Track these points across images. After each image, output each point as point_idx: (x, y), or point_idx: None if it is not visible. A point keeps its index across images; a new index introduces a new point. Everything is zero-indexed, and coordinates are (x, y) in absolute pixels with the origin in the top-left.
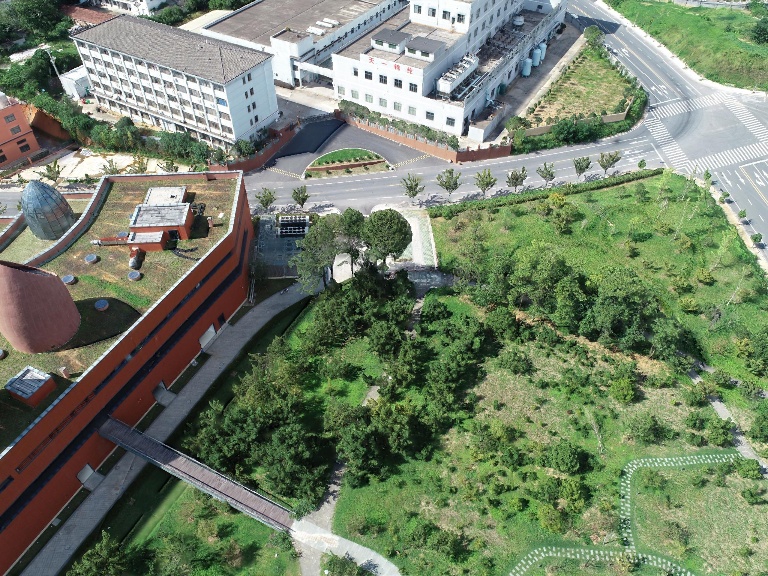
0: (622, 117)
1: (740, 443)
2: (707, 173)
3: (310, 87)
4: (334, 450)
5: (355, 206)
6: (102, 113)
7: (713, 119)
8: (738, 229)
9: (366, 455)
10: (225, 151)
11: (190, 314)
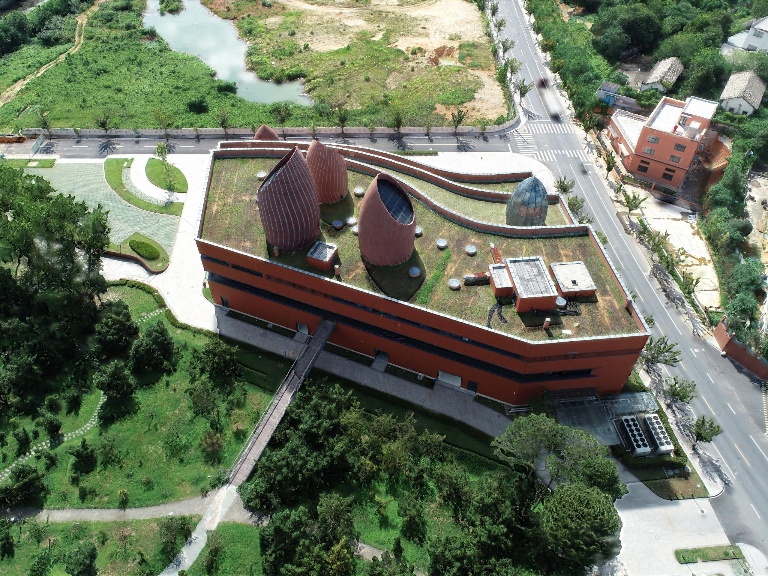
0: None
1: None
2: None
3: None
4: None
5: (742, 517)
6: (762, 208)
7: None
8: None
9: (277, 540)
10: (761, 331)
11: (442, 346)
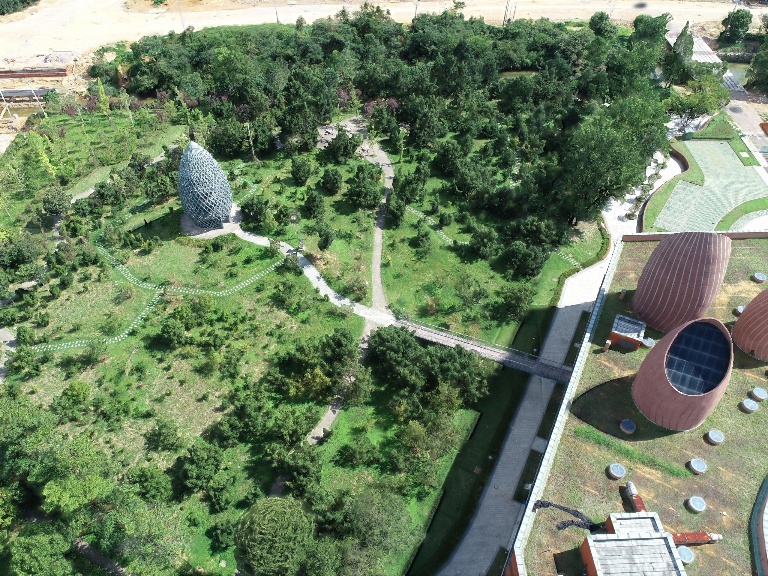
0: None
1: None
2: None
3: None
4: None
5: None
6: None
7: None
8: None
9: None
10: None
11: None
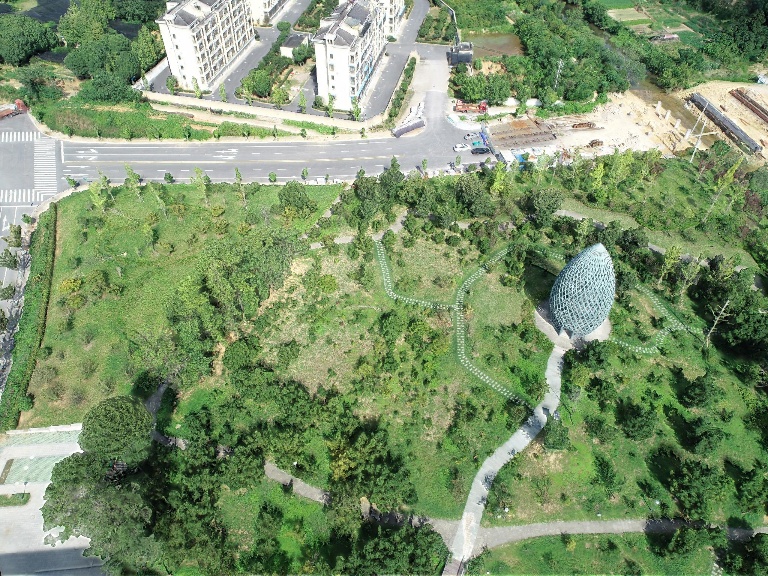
0: None
1: None
2: (70, 180)
3: None
4: (374, 525)
5: None
6: None
7: None
8: None
9: None
10: None
11: None
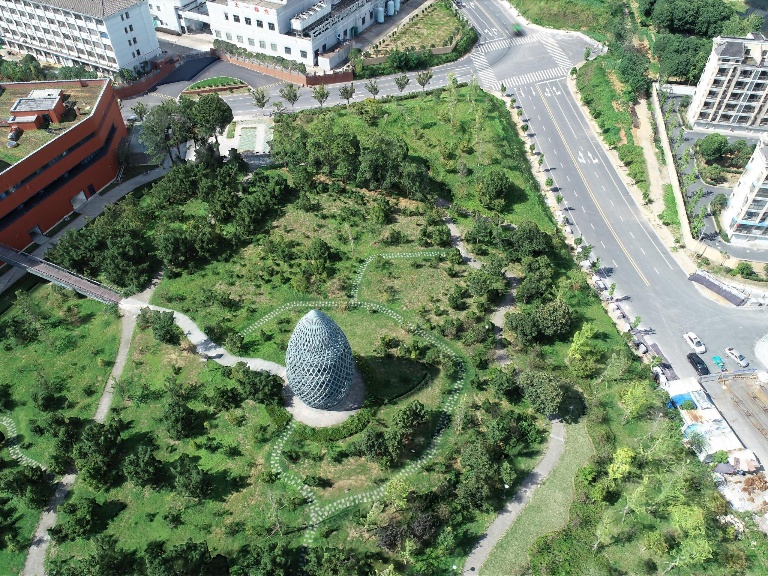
0: (449, 50)
1: (458, 246)
2: (502, 86)
3: (195, 34)
4: (161, 260)
5: None
6: (12, 56)
7: (527, 52)
8: (518, 125)
9: (176, 253)
10: (113, 80)
11: (59, 176)
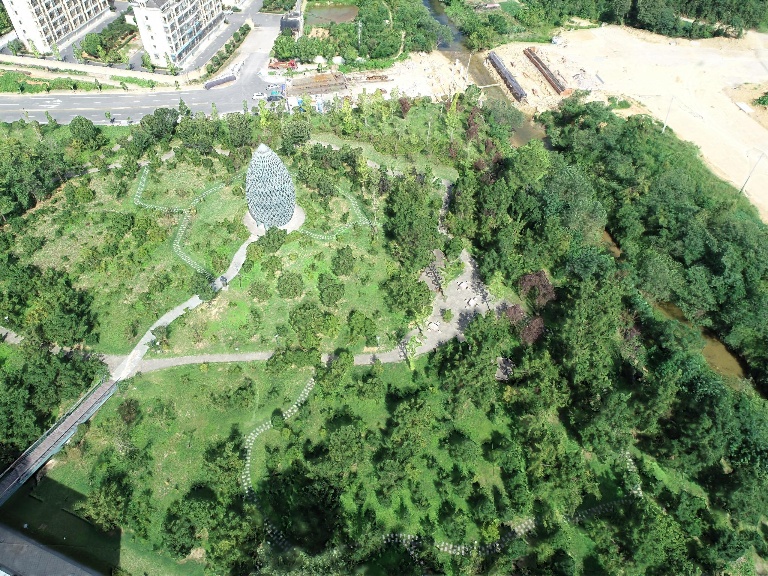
0: None
1: (139, 164)
2: None
3: None
4: None
5: None
6: None
7: None
8: None
9: None
10: None
11: None
